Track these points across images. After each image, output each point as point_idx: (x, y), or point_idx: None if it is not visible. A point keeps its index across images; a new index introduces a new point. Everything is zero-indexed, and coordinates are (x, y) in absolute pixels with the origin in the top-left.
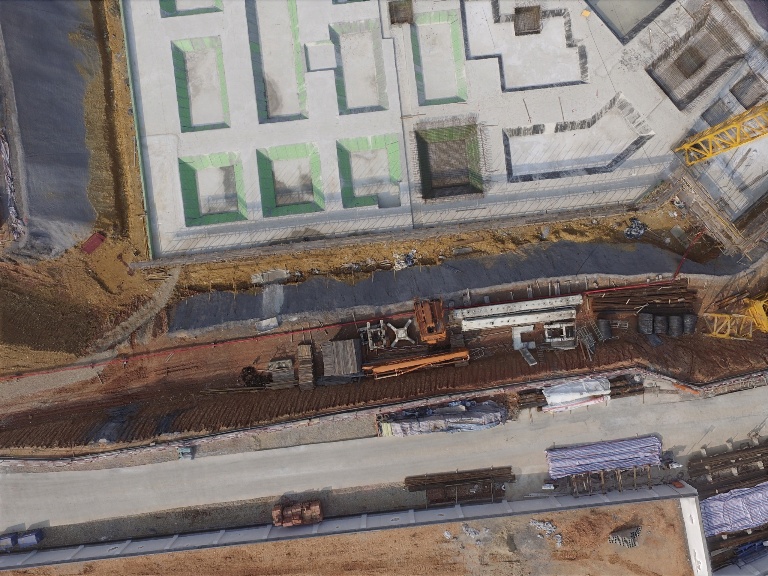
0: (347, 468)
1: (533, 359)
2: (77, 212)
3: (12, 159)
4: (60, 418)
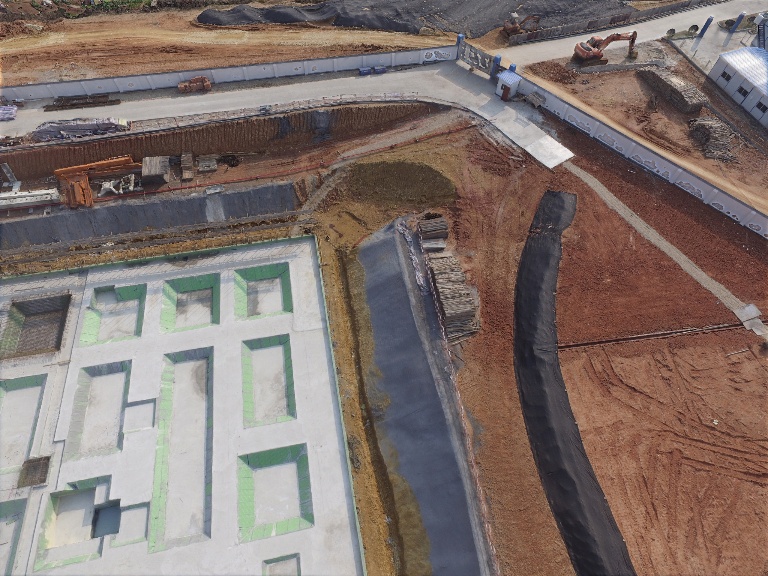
0: (158, 107)
1: (4, 169)
2: (369, 254)
3: (414, 274)
4: (363, 131)
